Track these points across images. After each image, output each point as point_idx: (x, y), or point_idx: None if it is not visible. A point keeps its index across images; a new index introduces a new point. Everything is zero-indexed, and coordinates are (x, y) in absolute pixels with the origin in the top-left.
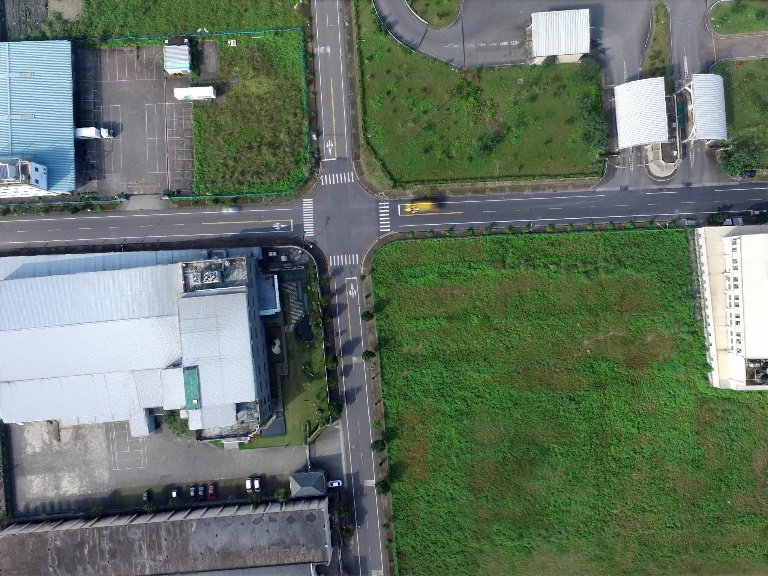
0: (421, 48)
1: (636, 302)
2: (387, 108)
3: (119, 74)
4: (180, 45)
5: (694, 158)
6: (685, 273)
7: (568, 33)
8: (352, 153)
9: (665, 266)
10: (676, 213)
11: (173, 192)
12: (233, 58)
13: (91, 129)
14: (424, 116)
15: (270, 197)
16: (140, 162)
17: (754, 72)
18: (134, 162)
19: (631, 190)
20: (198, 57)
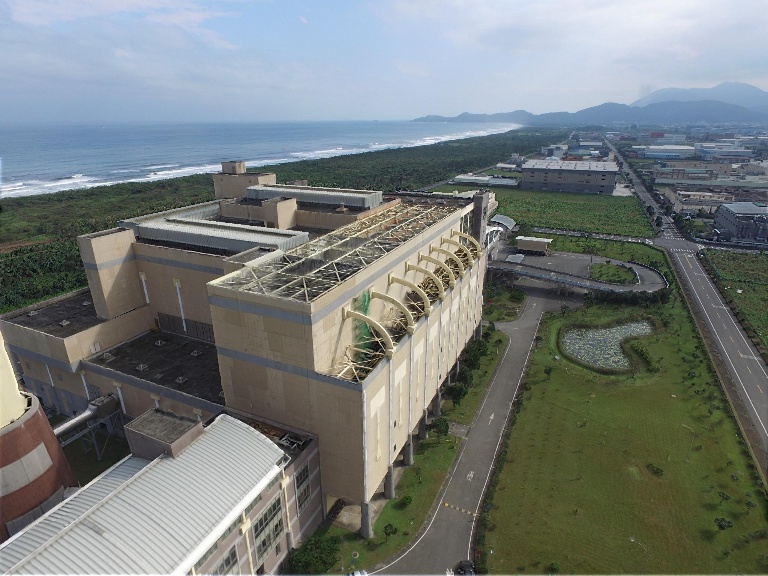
0: None
1: None
2: None
3: None
4: None
5: None
6: None
7: None
8: None
9: None
10: None
11: None
12: None
13: None
14: None
15: None
16: None
17: None
18: None
19: None
20: None
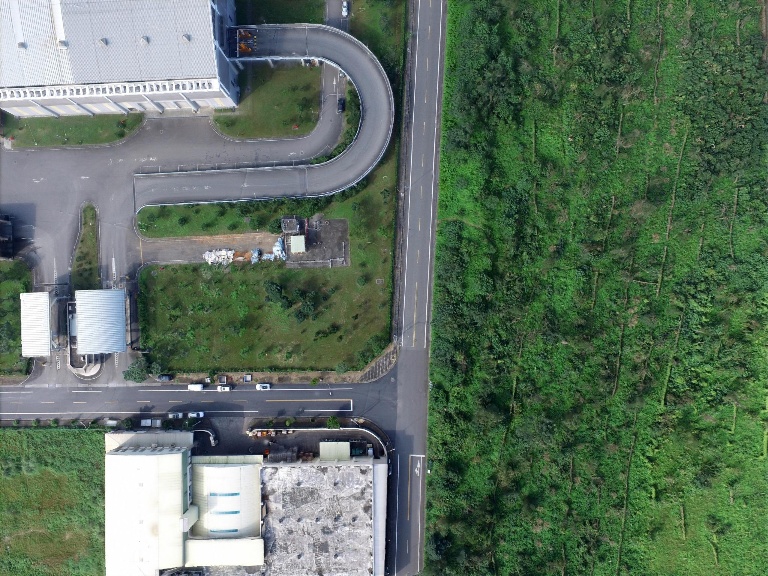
0: None
1: (56, 500)
2: None
3: None
4: None
5: (118, 358)
6: (102, 473)
7: None
8: None
9: (84, 465)
10: (100, 412)
11: None
12: None
13: None
14: None
15: None
16: None
17: (177, 276)
18: None
19: (58, 387)
20: None
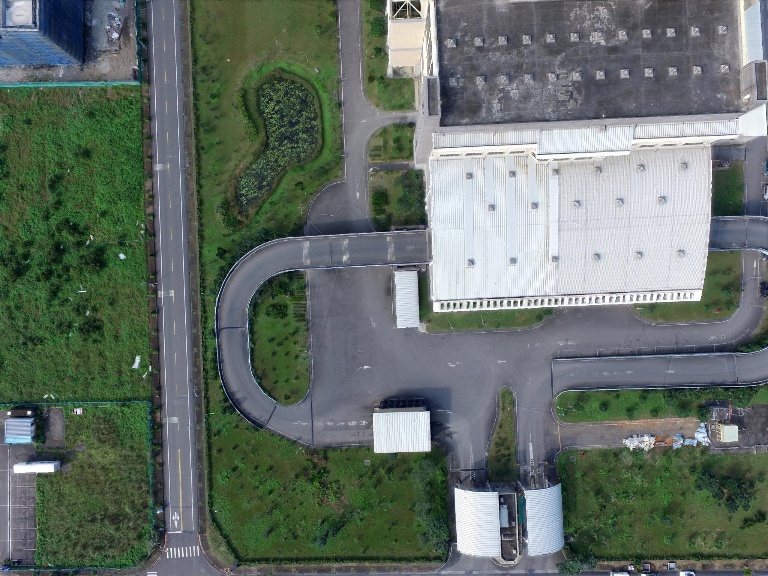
0: (269, 425)
1: None
2: (234, 483)
3: None
4: (23, 417)
5: None
6: None
7: (409, 433)
8: (198, 526)
9: None
10: None
11: (14, 562)
12: (79, 427)
13: None
14: (270, 495)
15: (114, 569)
16: None
17: (597, 462)
18: None
19: (475, 574)
20: (43, 424)
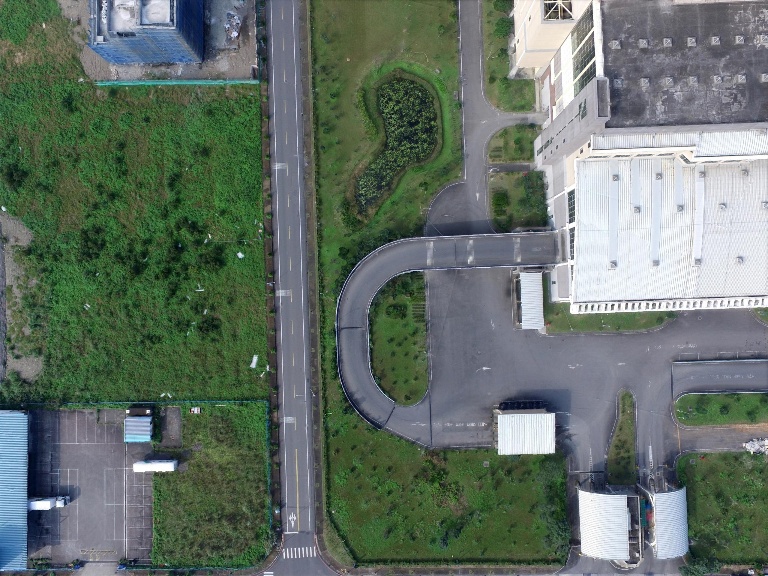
0: (388, 425)
1: None
2: (352, 484)
3: (78, 436)
4: (142, 416)
5: None
6: None
7: (534, 435)
8: (315, 527)
9: None
10: None
11: (130, 562)
12: (196, 426)
13: (46, 503)
14: (389, 496)
15: (230, 569)
16: (97, 528)
17: (717, 465)
18: (91, 528)
19: None
20: (160, 423)
